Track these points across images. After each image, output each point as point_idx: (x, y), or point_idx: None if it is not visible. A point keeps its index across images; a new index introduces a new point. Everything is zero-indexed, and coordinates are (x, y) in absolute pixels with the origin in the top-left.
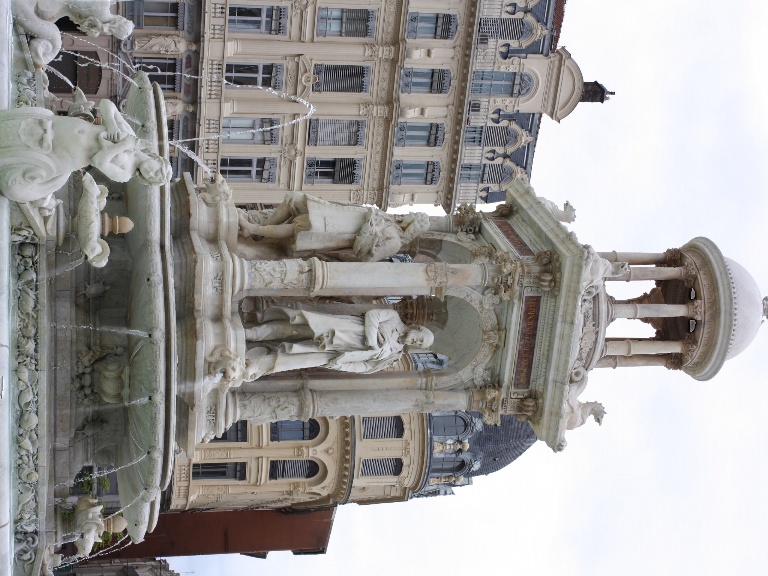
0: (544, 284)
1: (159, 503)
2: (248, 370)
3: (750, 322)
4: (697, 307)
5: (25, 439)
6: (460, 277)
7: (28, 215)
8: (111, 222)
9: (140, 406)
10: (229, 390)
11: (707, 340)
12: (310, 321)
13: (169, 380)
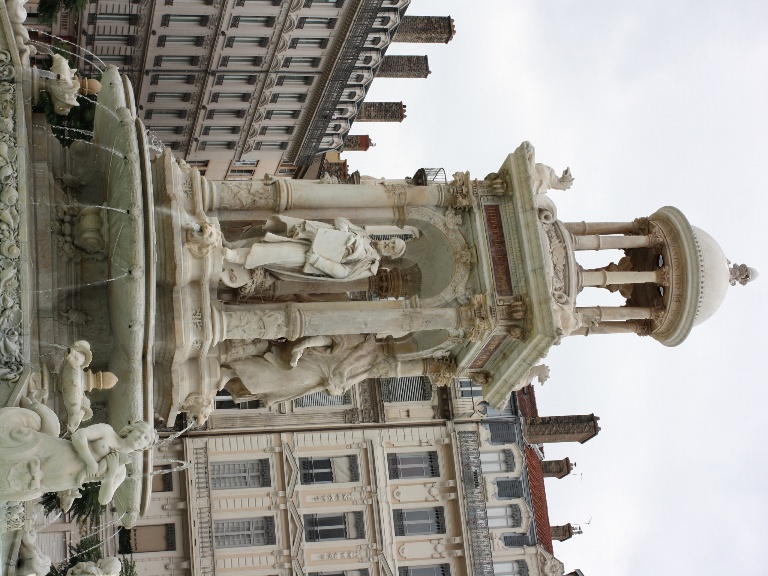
0: (497, 186)
1: (152, 401)
2: None
3: (713, 250)
4: (656, 233)
5: (6, 210)
6: (417, 190)
7: (4, 20)
8: (81, 81)
9: (117, 186)
10: None
11: (677, 262)
12: (281, 217)
13: (143, 156)
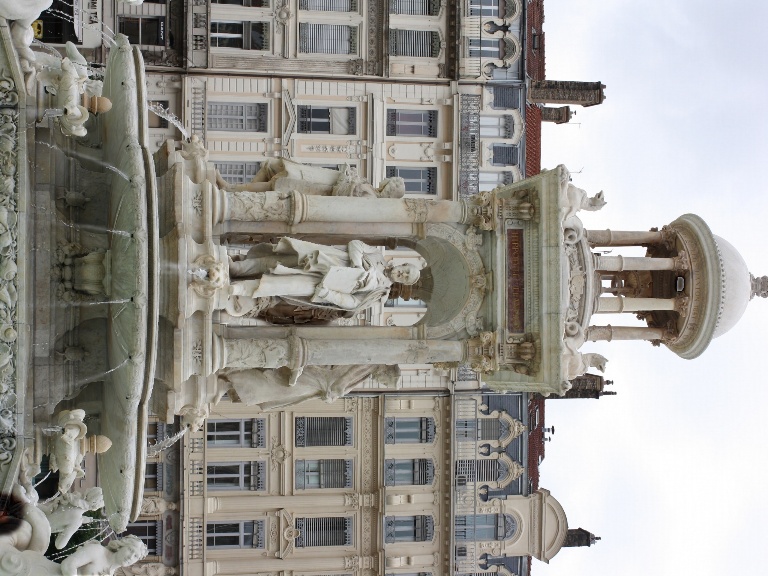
0: (524, 212)
1: None
2: (233, 285)
3: (738, 277)
4: (682, 257)
5: (3, 288)
6: (439, 208)
7: (9, 50)
8: (90, 99)
9: (122, 258)
10: (215, 332)
11: (698, 292)
12: (293, 243)
13: (151, 226)
